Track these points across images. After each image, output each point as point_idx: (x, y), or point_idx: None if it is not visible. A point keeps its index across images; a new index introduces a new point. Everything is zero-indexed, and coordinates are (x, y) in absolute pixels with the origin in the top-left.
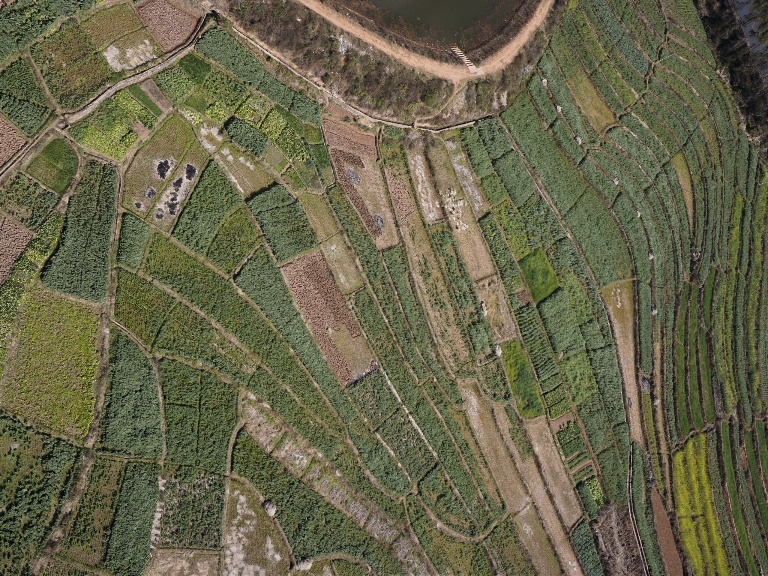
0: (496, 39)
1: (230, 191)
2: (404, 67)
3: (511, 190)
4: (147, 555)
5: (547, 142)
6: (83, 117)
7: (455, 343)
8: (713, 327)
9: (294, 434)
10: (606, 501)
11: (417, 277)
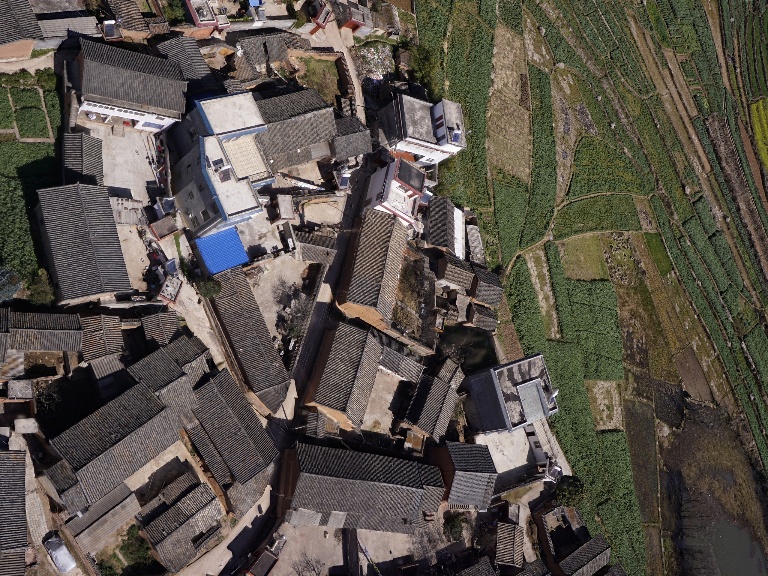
0: None
1: None
2: None
3: None
4: None
5: None
6: None
7: None
8: None
9: None
10: None
11: None
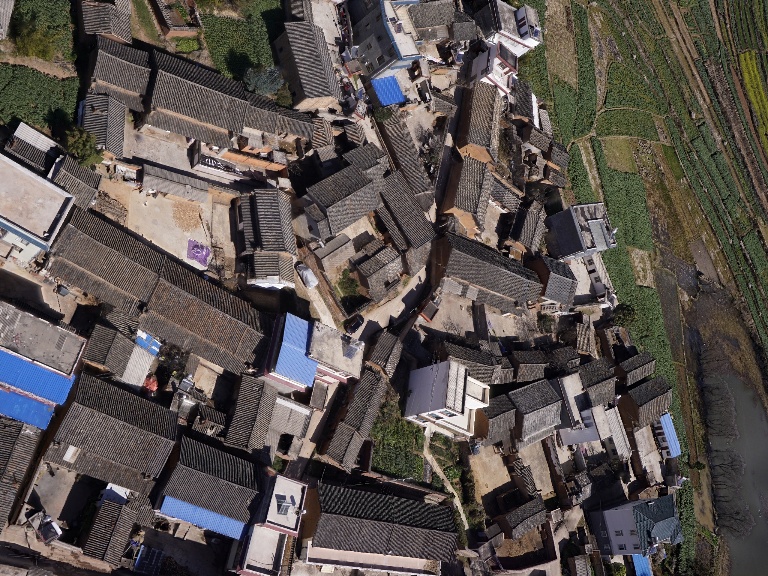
0: None
1: None
2: None
3: None
4: None
5: None
6: None
7: None
8: (753, 5)
9: None
10: None
11: None
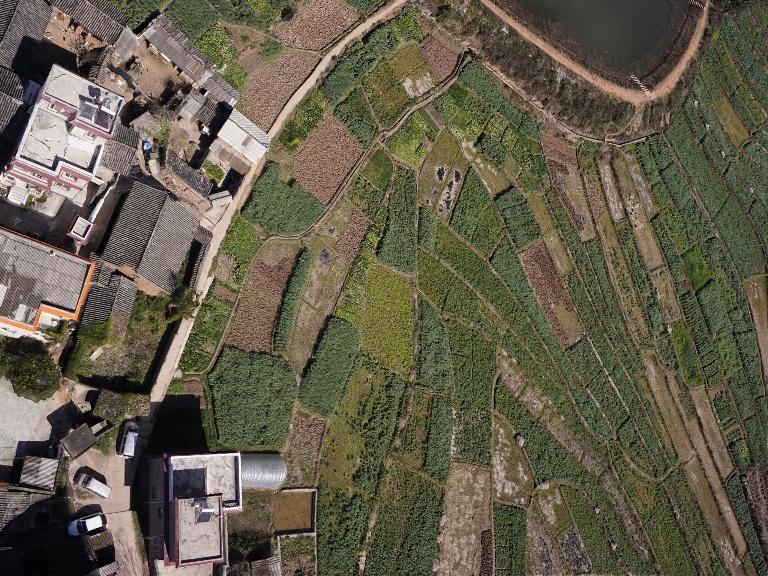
0: (662, 68)
1: (483, 192)
2: (602, 93)
3: (674, 196)
4: (450, 465)
5: (698, 155)
6: (393, 133)
7: (638, 321)
8: None
9: (532, 384)
10: (751, 460)
11: (609, 265)
